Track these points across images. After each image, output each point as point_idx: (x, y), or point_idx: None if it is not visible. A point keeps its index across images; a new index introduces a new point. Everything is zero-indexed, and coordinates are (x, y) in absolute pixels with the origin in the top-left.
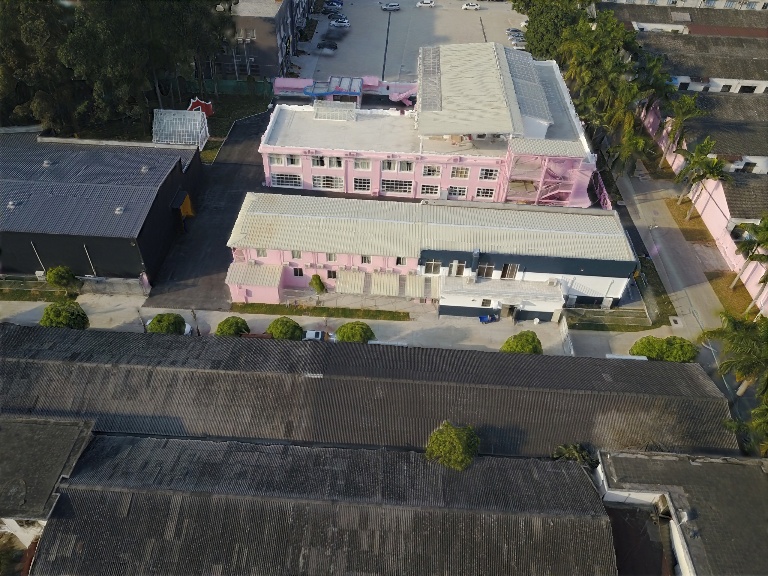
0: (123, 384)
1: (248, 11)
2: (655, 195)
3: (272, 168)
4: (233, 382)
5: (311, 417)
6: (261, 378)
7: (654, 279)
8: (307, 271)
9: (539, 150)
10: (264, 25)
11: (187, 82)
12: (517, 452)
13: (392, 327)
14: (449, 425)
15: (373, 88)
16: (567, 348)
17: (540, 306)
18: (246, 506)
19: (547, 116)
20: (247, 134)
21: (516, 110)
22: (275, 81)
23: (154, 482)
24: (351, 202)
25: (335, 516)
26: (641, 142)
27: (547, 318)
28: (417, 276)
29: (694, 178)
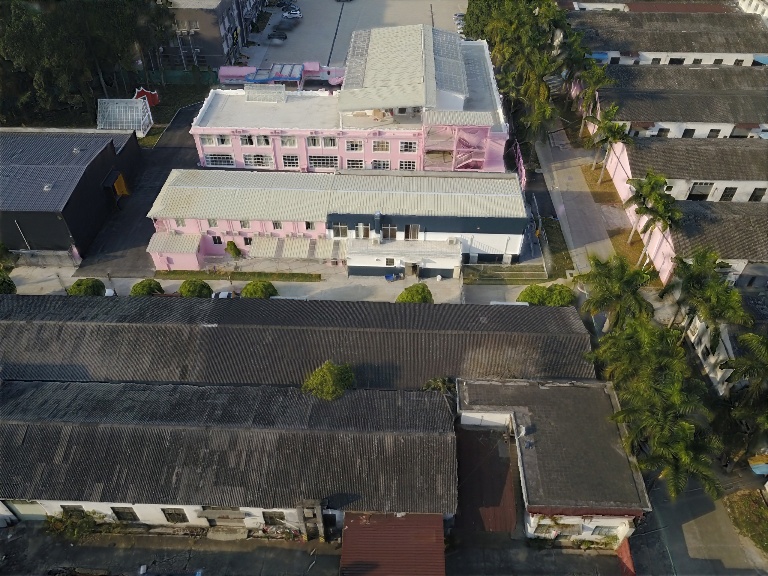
0: (35, 338)
1: (192, 4)
2: (572, 162)
3: (204, 149)
4: (136, 333)
5: (204, 361)
6: (161, 329)
7: (558, 238)
8: (225, 239)
9: (448, 121)
10: (206, 16)
11: (136, 74)
12: (391, 386)
13: (303, 287)
14: (329, 364)
15: (314, 73)
16: (465, 301)
17: (440, 263)
18: (129, 433)
19: (463, 90)
20: (190, 120)
21: (432, 85)
22: (219, 70)
23: (49, 416)
24: (269, 174)
25: (208, 439)
26: (548, 110)
27: (449, 275)
28: (327, 240)
29: (597, 142)
